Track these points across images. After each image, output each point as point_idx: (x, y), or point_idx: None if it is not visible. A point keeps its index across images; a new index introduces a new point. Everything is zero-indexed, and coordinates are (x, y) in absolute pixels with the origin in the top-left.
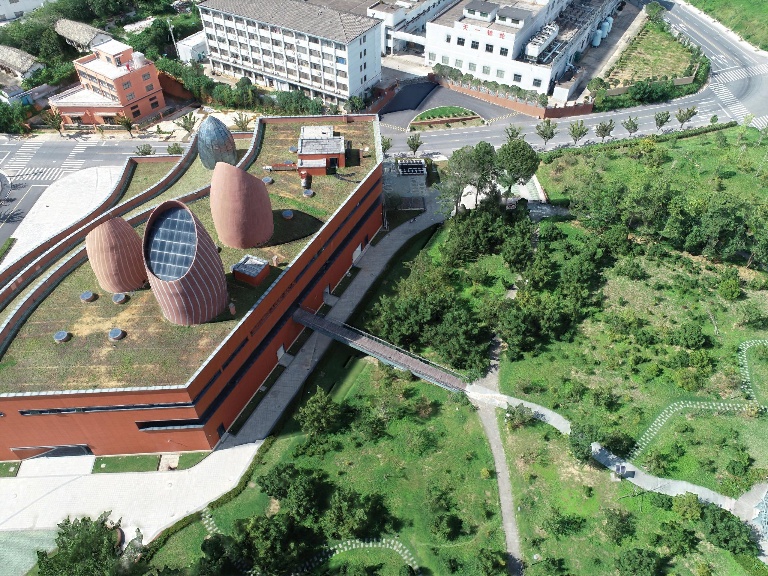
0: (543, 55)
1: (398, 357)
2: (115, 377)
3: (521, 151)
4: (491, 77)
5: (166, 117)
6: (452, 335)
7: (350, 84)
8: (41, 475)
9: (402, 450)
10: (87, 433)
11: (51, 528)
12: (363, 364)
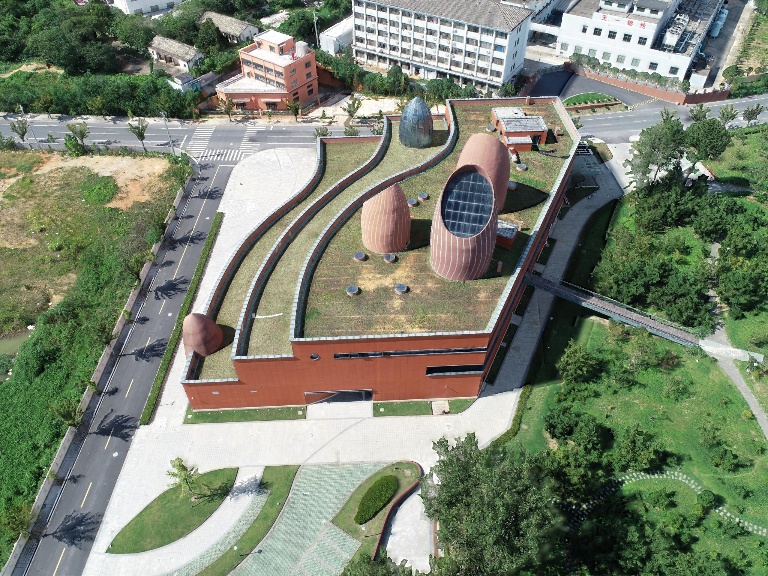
0: (676, 44)
1: (630, 315)
2: (416, 325)
3: (717, 128)
4: (625, 66)
5: (322, 103)
6: (681, 295)
7: (504, 71)
8: (328, 418)
9: (658, 396)
10: (379, 378)
11: (355, 462)
12: (591, 323)
